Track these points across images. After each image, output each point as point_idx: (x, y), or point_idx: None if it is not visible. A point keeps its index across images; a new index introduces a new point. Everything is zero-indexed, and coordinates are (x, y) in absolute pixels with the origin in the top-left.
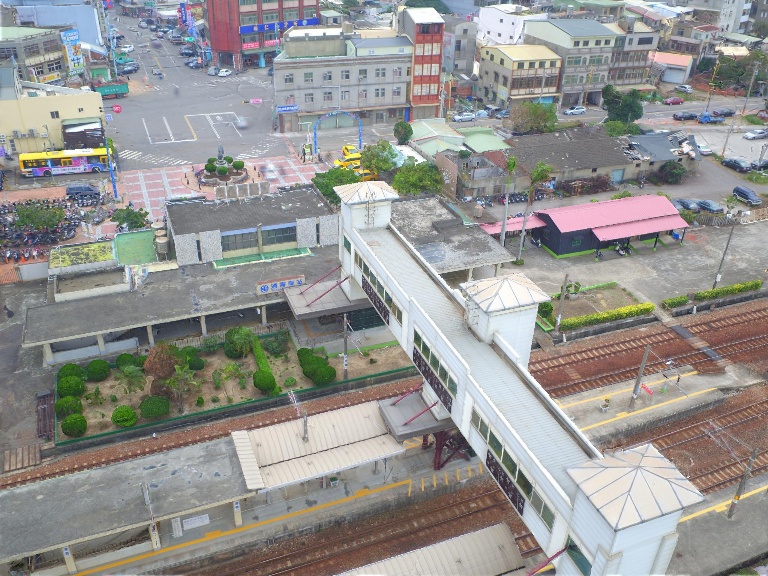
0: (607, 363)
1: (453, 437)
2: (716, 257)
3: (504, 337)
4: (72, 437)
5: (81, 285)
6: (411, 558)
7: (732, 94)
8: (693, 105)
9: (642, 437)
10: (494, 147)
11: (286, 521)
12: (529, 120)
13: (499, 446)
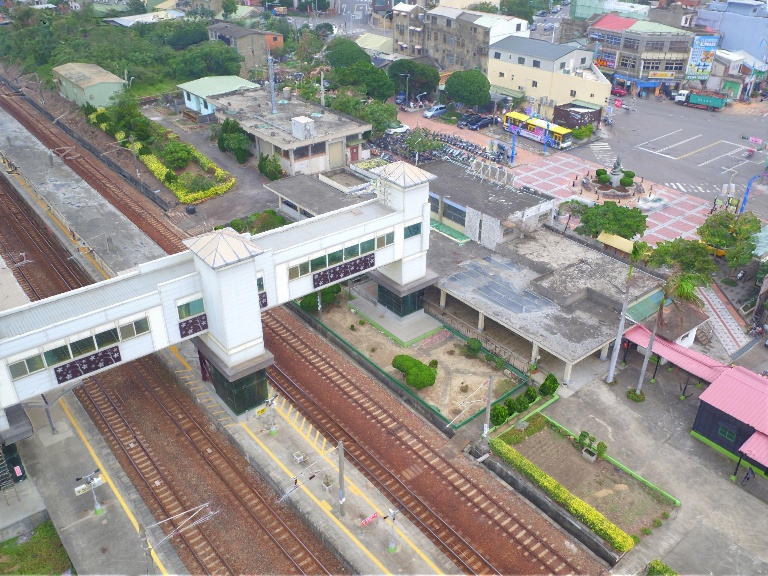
0: (453, 504)
1: (205, 358)
2: None
3: (206, 284)
4: None
5: (343, 179)
6: None
7: None
8: None
9: (311, 540)
10: None
11: None
12: None
13: None
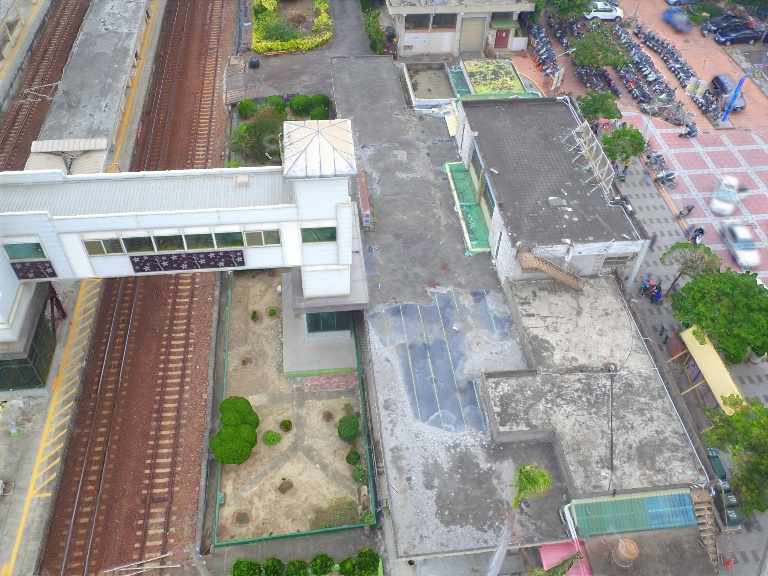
0: None
1: None
2: None
3: None
4: None
5: (432, 81)
6: None
7: None
8: None
9: None
10: None
11: None
12: None
13: None
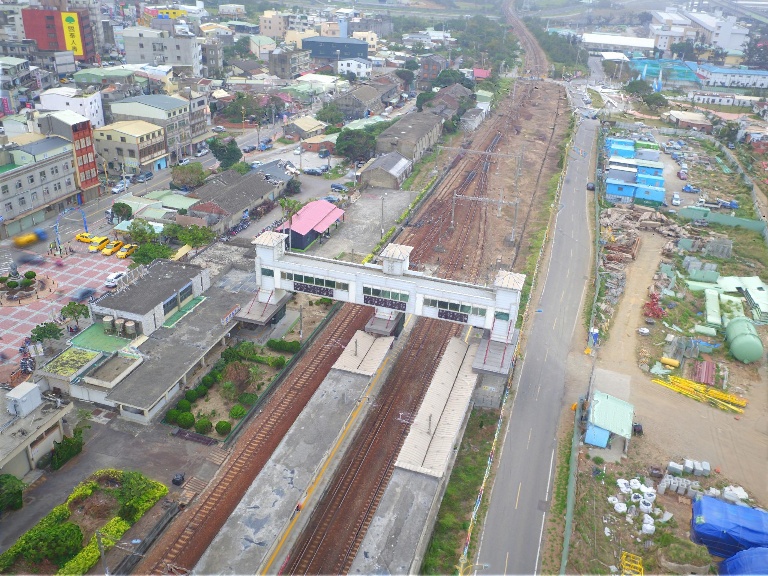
0: None
1: None
2: (364, 223)
3: None
4: (225, 435)
5: (107, 374)
6: (445, 359)
7: (266, 128)
8: (241, 140)
9: None
10: (189, 202)
11: (370, 394)
12: (191, 177)
13: (445, 304)
